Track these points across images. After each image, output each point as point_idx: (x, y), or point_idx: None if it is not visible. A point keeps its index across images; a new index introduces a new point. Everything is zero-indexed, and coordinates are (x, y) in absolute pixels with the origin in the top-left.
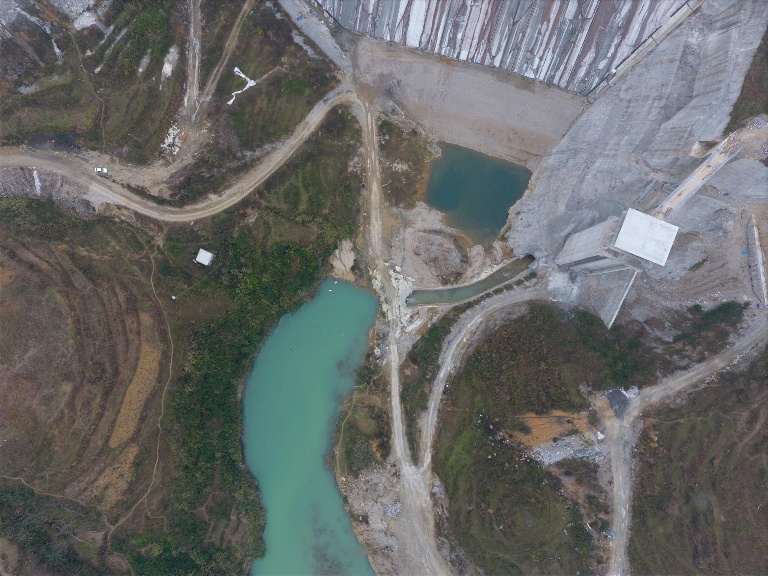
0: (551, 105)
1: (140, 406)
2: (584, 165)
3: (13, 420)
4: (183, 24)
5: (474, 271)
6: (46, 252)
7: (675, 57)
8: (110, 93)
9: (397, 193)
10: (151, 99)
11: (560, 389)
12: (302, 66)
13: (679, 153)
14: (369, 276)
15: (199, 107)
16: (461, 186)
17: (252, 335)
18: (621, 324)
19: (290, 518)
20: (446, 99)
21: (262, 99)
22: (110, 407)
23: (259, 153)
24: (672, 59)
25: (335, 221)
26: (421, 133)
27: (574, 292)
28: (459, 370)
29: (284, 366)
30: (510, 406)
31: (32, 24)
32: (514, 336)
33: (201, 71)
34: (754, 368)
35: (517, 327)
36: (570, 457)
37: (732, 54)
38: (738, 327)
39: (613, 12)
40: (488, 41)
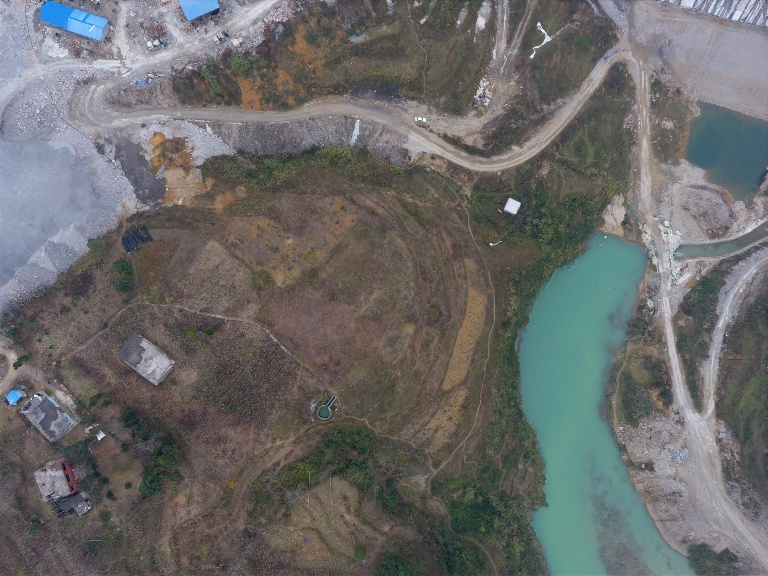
0: None
1: (471, 349)
2: None
3: (362, 361)
4: None
5: (740, 225)
6: (380, 197)
7: None
8: (432, 44)
9: (666, 150)
10: (468, 51)
11: None
12: (589, 24)
13: None
14: (639, 230)
15: (507, 60)
16: (717, 145)
17: None
18: None
19: (566, 468)
20: (714, 59)
21: (557, 54)
22: (444, 350)
23: (553, 107)
24: None
25: (614, 175)
26: (684, 92)
27: None
28: (738, 319)
29: (554, 319)
30: None
31: None
32: None
33: (509, 25)
34: None
35: None
36: None
37: None
38: None
39: None
40: (766, 1)
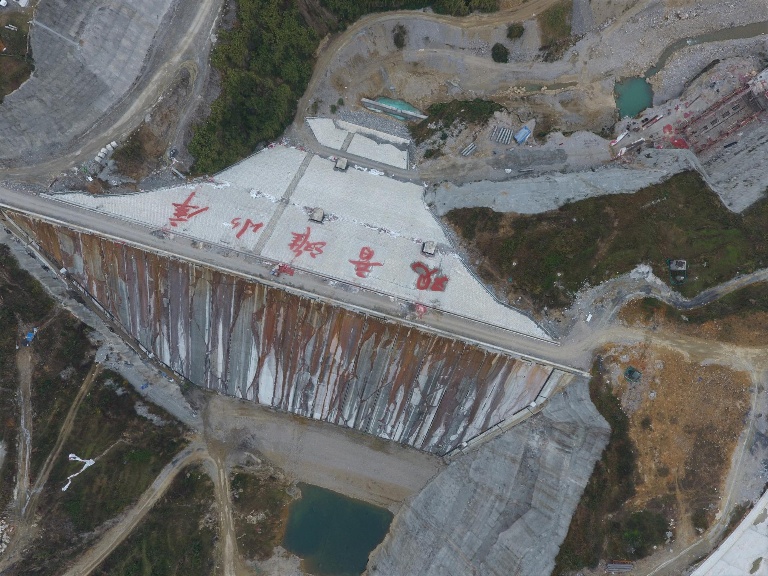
0: (406, 465)
1: None
2: (430, 550)
3: None
4: (13, 416)
5: None
6: None
7: (516, 458)
8: None
9: (252, 546)
10: None
11: None
12: (147, 436)
13: None
14: None
15: (29, 500)
16: (323, 525)
17: None
18: None
19: None
20: (302, 451)
21: (101, 477)
22: None
23: (98, 531)
24: (514, 459)
25: None
26: (279, 478)
27: None
28: None
29: None
30: None
31: None
32: None
33: (32, 464)
34: None
35: None
36: None
37: (563, 483)
38: None
39: (457, 405)
40: (339, 409)
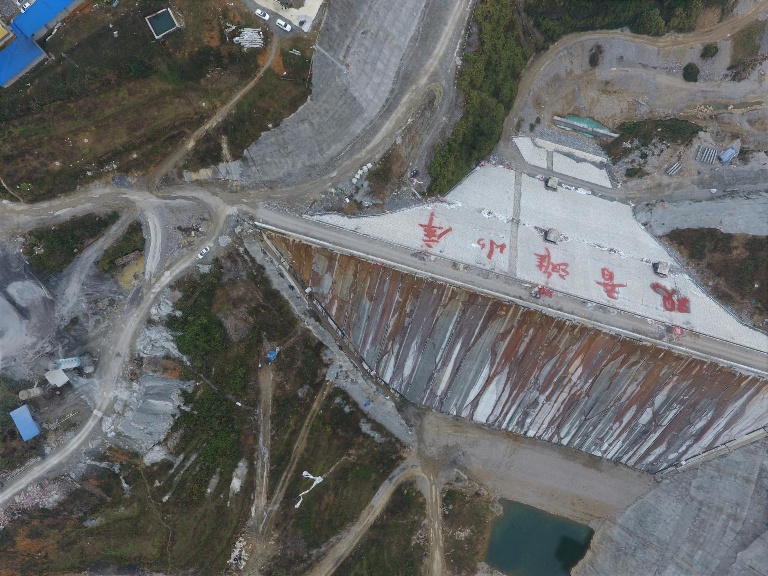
0: (618, 483)
1: None
2: (655, 568)
3: None
4: (252, 434)
5: None
6: None
7: (750, 478)
8: (177, 518)
9: (460, 562)
10: (219, 519)
11: None
12: (369, 453)
13: None
14: None
15: (267, 517)
16: (522, 541)
17: None
18: None
19: None
20: (511, 468)
21: (329, 494)
22: None
23: (325, 548)
24: (747, 478)
25: None
26: (483, 494)
27: None
28: None
29: None
30: None
31: (101, 469)
32: None
33: (270, 481)
34: None
35: None
36: None
37: None
38: None
39: (688, 424)
40: (557, 427)
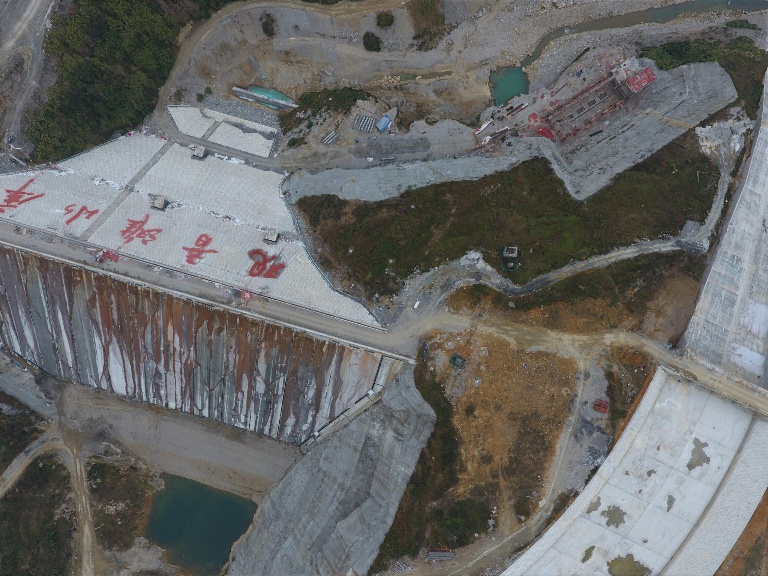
0: (263, 455)
1: None
2: (277, 540)
3: None
4: None
5: None
6: None
7: (358, 447)
8: None
9: (110, 536)
10: None
11: None
12: None
13: None
14: None
15: None
16: (187, 516)
17: None
18: None
19: None
20: (160, 441)
21: None
22: None
23: None
24: (355, 447)
25: (37, 574)
26: (141, 468)
27: None
28: None
29: None
30: None
31: None
32: None
33: None
34: None
35: None
36: None
37: (394, 471)
38: None
39: (300, 393)
40: (191, 399)
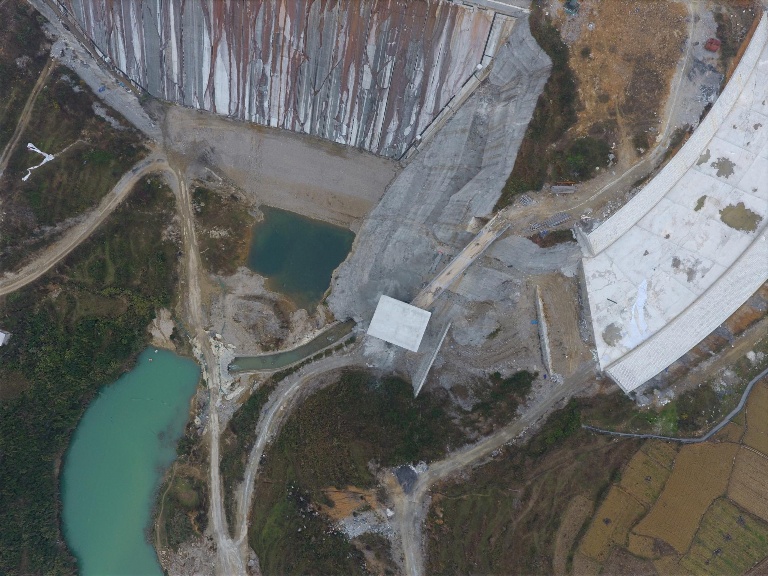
0: (363, 170)
1: None
2: (387, 233)
3: None
4: None
5: (296, 336)
6: None
7: (466, 127)
8: None
9: (215, 260)
10: None
11: (350, 466)
12: (105, 138)
13: (457, 228)
14: (189, 344)
15: None
16: (286, 249)
17: (64, 410)
18: (429, 391)
19: None
20: (261, 165)
21: (61, 173)
22: None
23: (60, 227)
24: (464, 129)
25: (148, 291)
26: (241, 198)
27: (391, 357)
28: (275, 439)
29: (106, 437)
30: (314, 479)
31: None
32: (317, 408)
33: None
34: (531, 443)
35: (321, 399)
36: (369, 532)
37: (509, 128)
38: (526, 398)
39: (407, 82)
40: (294, 109)
